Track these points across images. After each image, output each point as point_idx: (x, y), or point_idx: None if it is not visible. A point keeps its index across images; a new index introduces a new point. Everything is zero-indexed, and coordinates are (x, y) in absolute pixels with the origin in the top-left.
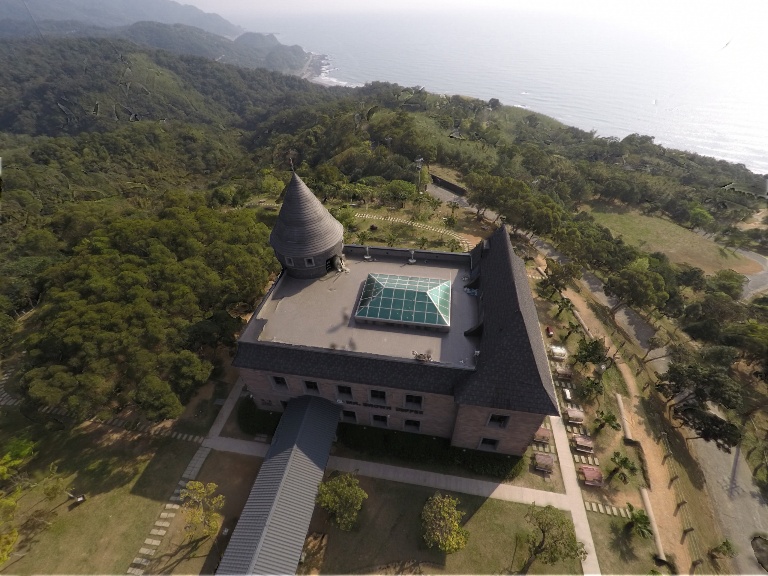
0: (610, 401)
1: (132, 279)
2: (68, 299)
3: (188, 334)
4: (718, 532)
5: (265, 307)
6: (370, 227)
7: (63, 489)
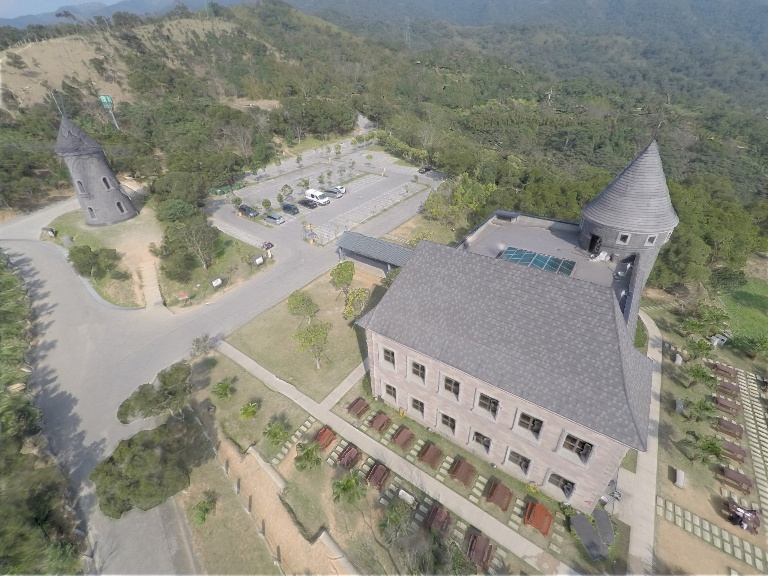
0: (374, 570)
1: (582, 189)
2: (567, 183)
3: None
4: (204, 575)
5: (538, 223)
6: None
7: (456, 220)
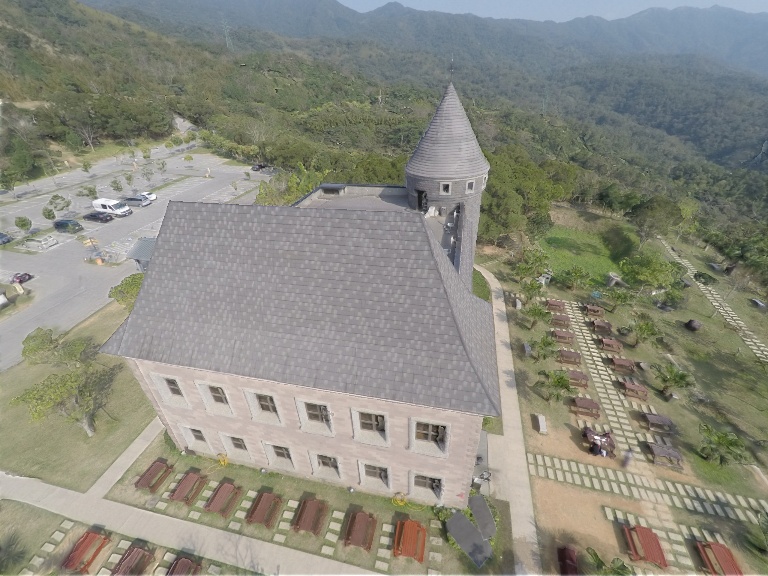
0: None
1: None
2: None
3: None
4: None
5: (367, 192)
6: (688, 321)
7: None
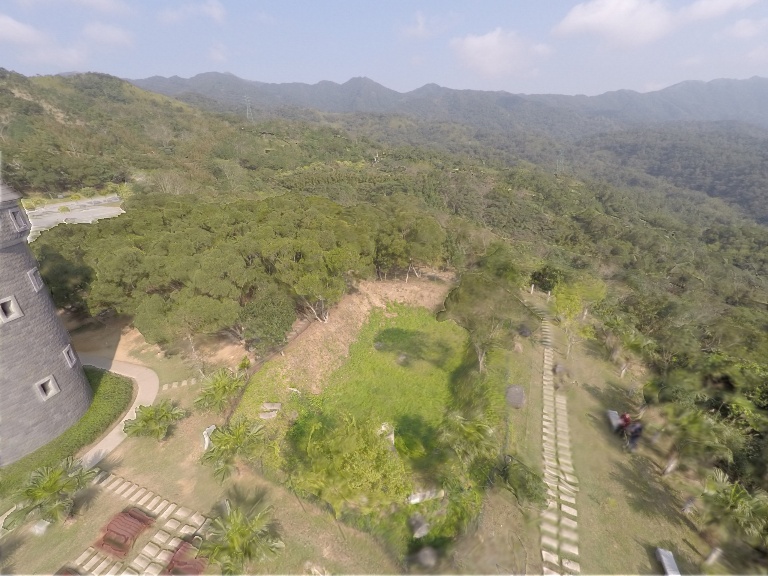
0: None
1: None
2: None
3: (42, 251)
4: None
5: None
6: None
7: None
